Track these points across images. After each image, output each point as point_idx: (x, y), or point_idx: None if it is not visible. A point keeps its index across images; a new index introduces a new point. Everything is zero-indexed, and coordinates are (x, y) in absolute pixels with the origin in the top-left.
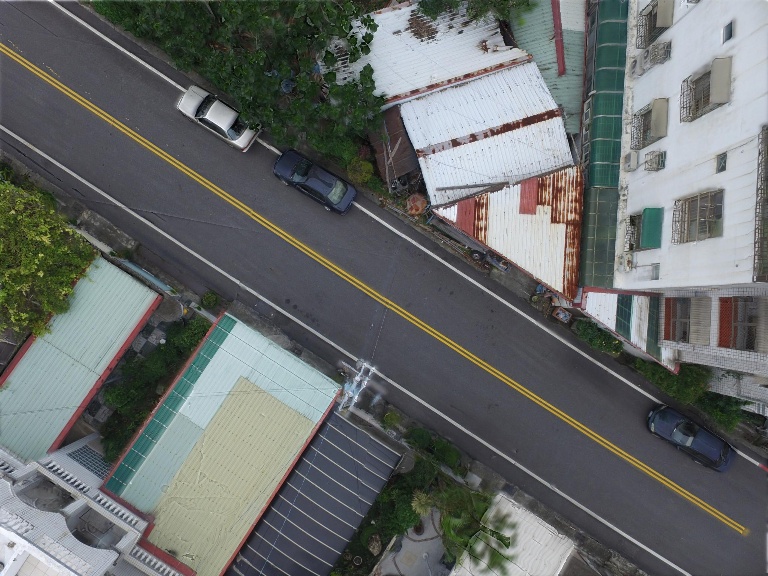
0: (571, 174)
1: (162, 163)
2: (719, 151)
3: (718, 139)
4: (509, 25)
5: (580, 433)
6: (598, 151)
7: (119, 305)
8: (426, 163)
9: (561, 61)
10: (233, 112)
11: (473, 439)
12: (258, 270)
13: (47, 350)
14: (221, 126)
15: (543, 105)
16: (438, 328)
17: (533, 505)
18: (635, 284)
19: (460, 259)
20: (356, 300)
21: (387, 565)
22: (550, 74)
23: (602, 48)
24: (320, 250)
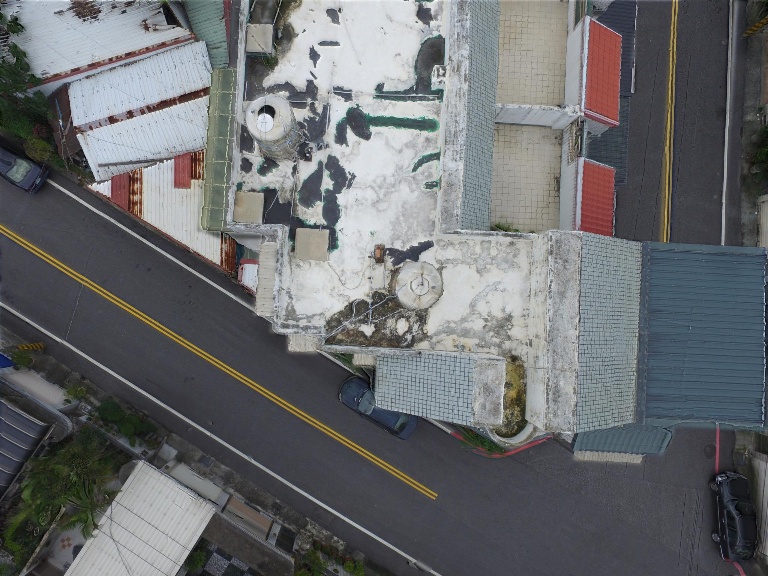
0: None
1: None
2: None
3: None
4: (184, 5)
5: (275, 405)
6: None
7: None
8: (85, 139)
9: None
10: None
11: (168, 412)
12: None
13: None
14: None
15: (202, 82)
16: (135, 304)
17: (229, 476)
18: None
19: (160, 236)
20: (51, 277)
21: (75, 536)
22: (219, 53)
23: None
24: (15, 228)
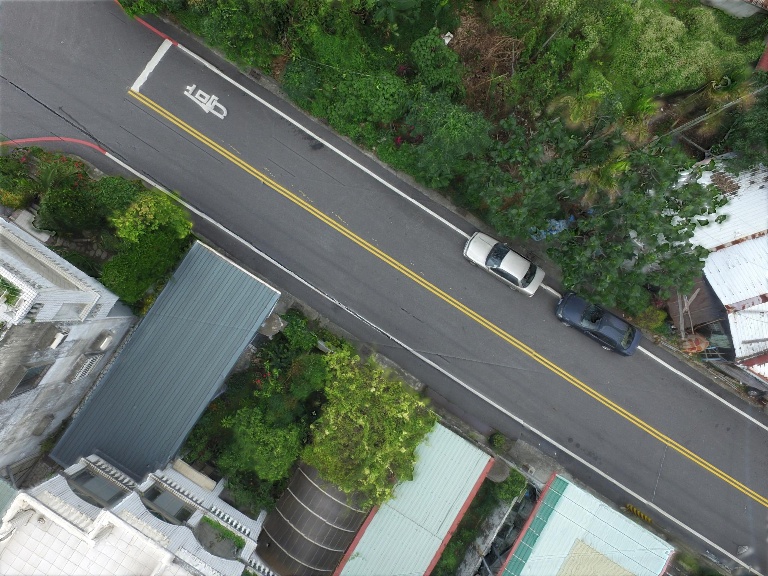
0: None
1: (446, 306)
2: None
3: None
4: None
5: None
6: None
7: (454, 468)
8: (735, 318)
9: None
10: (526, 262)
11: (756, 575)
12: (541, 410)
13: (392, 516)
14: (517, 277)
15: None
16: (717, 465)
17: None
18: None
19: (734, 394)
20: (637, 438)
21: None
22: None
23: None
24: (600, 389)
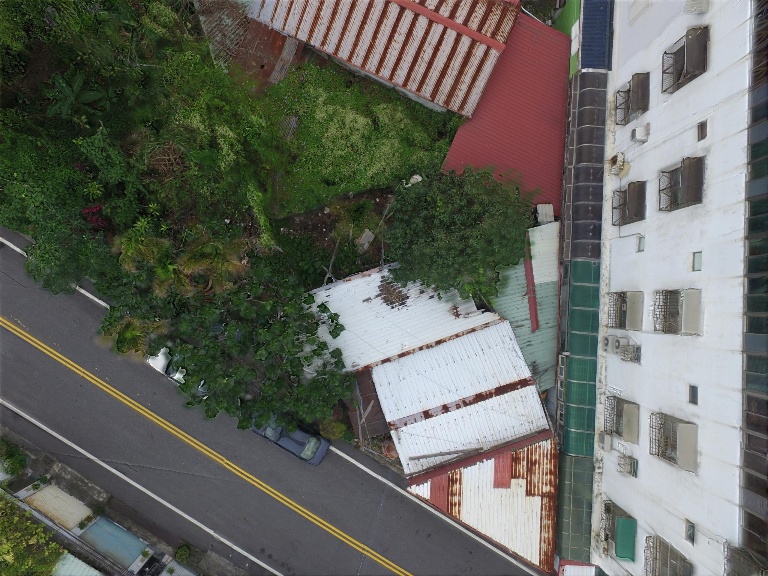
0: (545, 446)
1: (133, 413)
2: (687, 517)
3: (686, 502)
4: None
5: None
6: (572, 417)
7: None
8: (398, 435)
9: (534, 318)
10: None
11: None
12: (232, 520)
13: None
14: None
15: (516, 372)
16: (416, 572)
17: None
18: (611, 574)
19: None
20: (332, 547)
21: None
22: (523, 332)
23: (575, 311)
24: (295, 497)
